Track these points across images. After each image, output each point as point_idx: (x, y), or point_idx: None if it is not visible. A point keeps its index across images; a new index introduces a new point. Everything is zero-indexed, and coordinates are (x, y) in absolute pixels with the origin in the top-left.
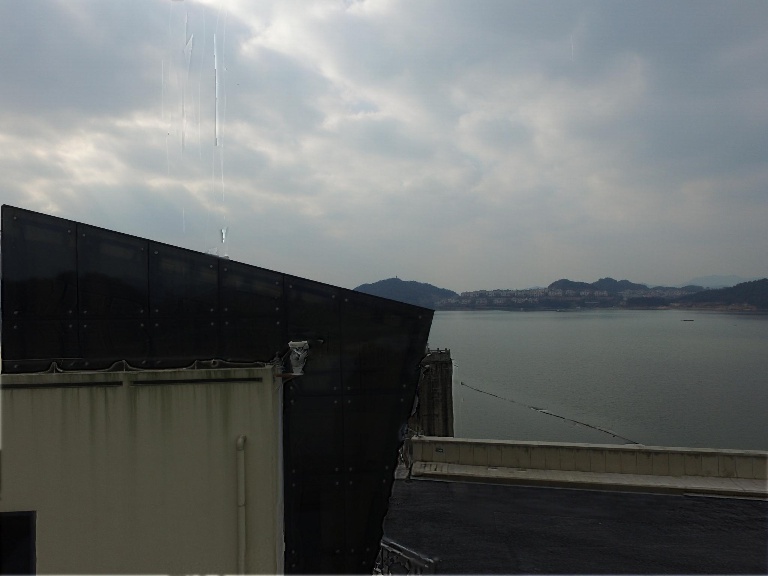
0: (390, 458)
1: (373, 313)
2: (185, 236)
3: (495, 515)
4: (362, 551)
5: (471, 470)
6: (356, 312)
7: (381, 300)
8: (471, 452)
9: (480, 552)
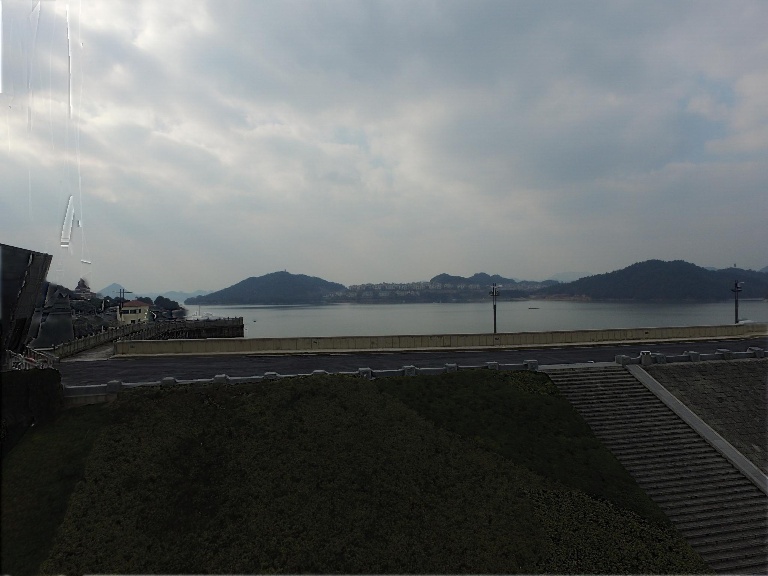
0: (13, 302)
1: (9, 252)
2: (32, 222)
3: (135, 364)
4: (1, 333)
5: (146, 354)
6: (0, 251)
7: (10, 247)
8: (150, 347)
9: (107, 370)
